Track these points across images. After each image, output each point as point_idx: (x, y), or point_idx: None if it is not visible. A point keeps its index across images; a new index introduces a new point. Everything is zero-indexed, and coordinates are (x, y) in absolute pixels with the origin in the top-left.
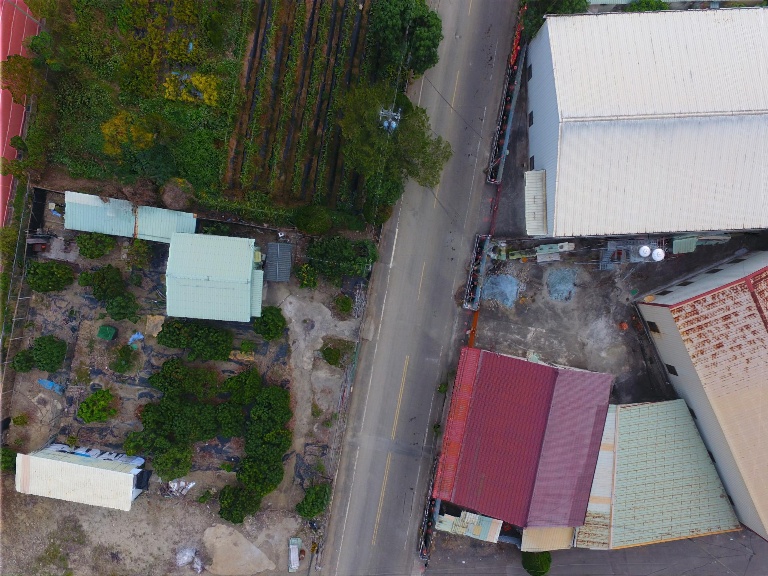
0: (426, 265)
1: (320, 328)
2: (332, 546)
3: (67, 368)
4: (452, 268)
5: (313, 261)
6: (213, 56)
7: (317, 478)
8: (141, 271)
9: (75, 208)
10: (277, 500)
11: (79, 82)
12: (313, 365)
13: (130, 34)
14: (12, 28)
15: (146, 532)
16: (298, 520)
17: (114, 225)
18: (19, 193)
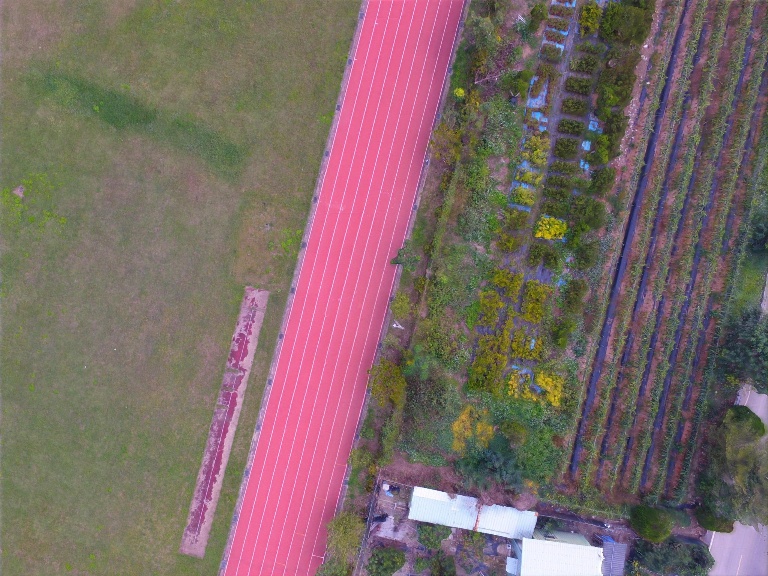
0: (743, 558)
1: None
2: None
3: None
4: (767, 562)
5: (645, 560)
6: (556, 356)
7: None
8: (465, 552)
9: (421, 501)
10: None
11: (433, 380)
12: None
13: (483, 335)
14: (361, 316)
15: None
16: None
17: (456, 518)
18: (355, 473)
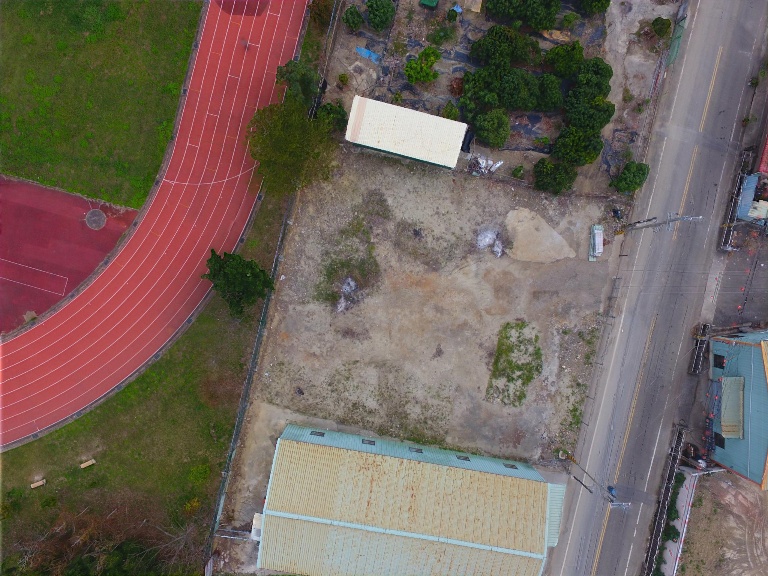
0: None
1: (637, 11)
2: (632, 238)
3: (385, 38)
4: None
5: None
6: None
7: (623, 166)
8: None
9: None
10: (582, 186)
11: None
12: (627, 49)
13: None
14: None
15: (449, 211)
16: (601, 208)
17: None
18: None
